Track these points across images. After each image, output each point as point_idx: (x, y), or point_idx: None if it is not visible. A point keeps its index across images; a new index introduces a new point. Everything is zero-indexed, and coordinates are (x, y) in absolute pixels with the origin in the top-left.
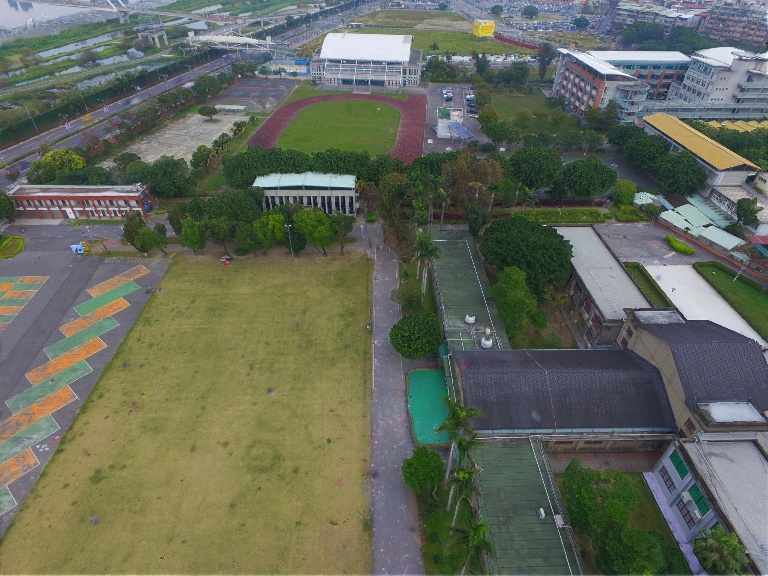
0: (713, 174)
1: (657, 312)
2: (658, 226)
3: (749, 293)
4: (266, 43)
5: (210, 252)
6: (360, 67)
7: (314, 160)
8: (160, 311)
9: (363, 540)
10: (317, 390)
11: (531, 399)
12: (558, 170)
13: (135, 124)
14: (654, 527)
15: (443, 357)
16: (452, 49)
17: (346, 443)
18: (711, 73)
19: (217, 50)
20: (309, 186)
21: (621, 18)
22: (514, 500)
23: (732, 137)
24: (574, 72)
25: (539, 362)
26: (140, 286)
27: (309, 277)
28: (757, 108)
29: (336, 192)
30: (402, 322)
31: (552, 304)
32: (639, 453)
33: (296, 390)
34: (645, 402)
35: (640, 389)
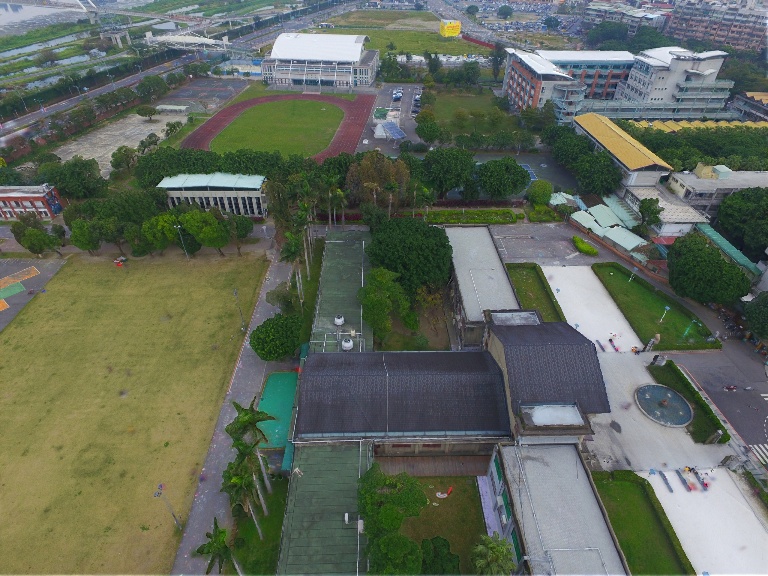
0: (627, 174)
1: (516, 314)
2: (569, 226)
3: (641, 294)
4: (223, 43)
5: (107, 253)
6: (310, 67)
7: (223, 160)
8: (37, 313)
9: (170, 546)
10: (170, 393)
11: (367, 402)
12: (468, 170)
13: (68, 124)
14: (471, 532)
15: (301, 359)
16: (415, 49)
17: (183, 447)
18: (650, 73)
19: (176, 50)
20: (213, 187)
21: (590, 18)
22: (324, 505)
23: (653, 137)
24: (518, 72)
25: (388, 364)
26: (25, 288)
27: (199, 278)
28: (697, 108)
29: (241, 193)
30: (263, 324)
31: (423, 305)
32: (479, 456)
33: (149, 393)
34: (483, 405)
35: (480, 392)
